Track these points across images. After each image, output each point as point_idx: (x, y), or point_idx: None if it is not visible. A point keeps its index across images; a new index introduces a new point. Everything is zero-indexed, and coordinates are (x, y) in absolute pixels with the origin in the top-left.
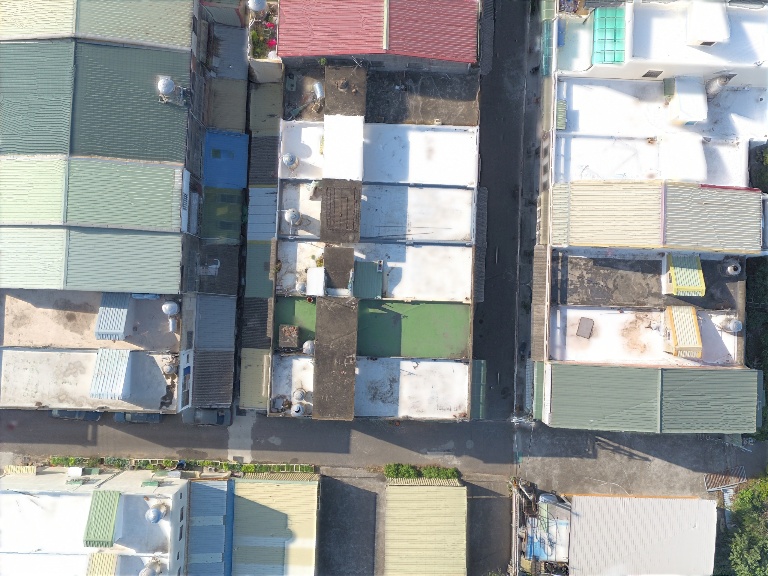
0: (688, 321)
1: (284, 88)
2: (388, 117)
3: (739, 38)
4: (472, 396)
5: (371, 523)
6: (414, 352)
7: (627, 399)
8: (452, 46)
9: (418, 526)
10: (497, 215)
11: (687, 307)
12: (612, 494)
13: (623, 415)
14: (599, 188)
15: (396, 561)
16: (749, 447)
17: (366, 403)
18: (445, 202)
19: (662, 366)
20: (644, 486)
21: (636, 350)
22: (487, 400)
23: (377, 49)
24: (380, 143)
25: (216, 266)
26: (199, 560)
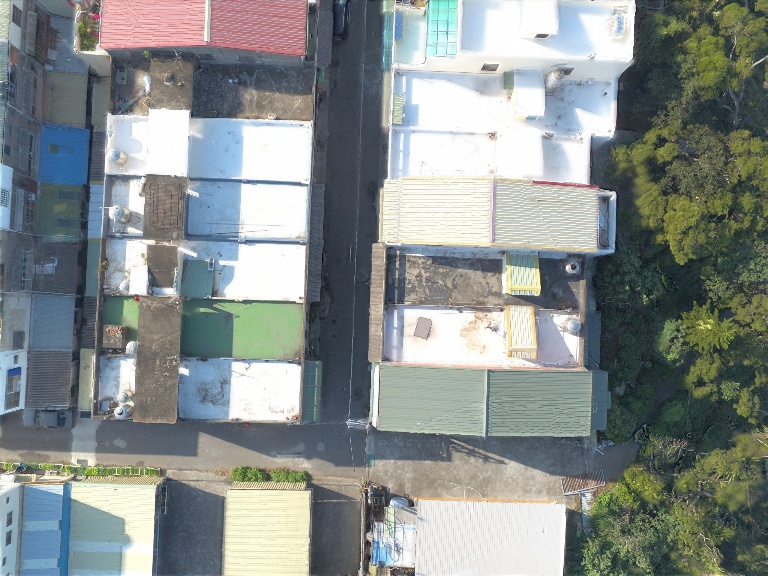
0: (525, 321)
1: (114, 81)
2: (222, 111)
3: (575, 30)
4: (305, 398)
5: (219, 528)
6: (246, 353)
7: (454, 401)
8: (279, 38)
9: (259, 531)
10: (351, 212)
11: (526, 307)
12: (465, 498)
13: (450, 418)
14: (428, 184)
15: (236, 567)
16: (609, 450)
17: (196, 405)
18: (279, 199)
19: (490, 367)
20: (499, 490)
21: (475, 351)
22: (339, 402)
23: (198, 41)
24: (213, 138)
25: (53, 264)
26: (33, 566)
